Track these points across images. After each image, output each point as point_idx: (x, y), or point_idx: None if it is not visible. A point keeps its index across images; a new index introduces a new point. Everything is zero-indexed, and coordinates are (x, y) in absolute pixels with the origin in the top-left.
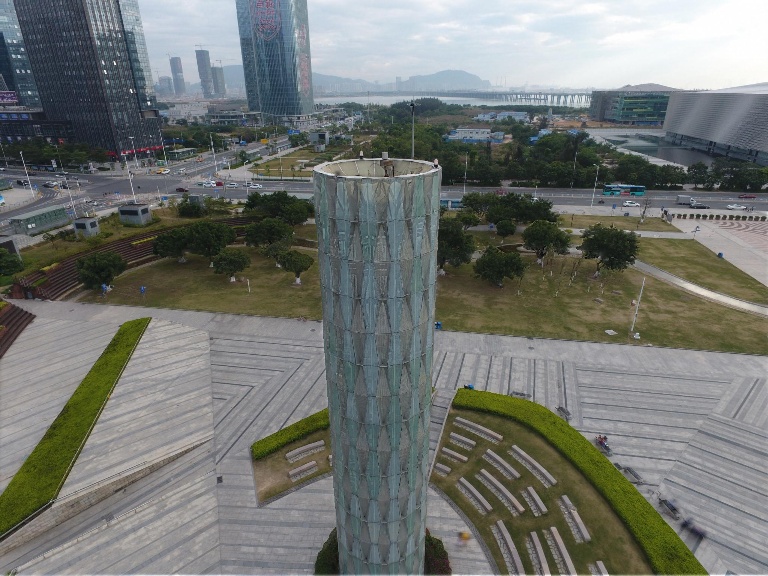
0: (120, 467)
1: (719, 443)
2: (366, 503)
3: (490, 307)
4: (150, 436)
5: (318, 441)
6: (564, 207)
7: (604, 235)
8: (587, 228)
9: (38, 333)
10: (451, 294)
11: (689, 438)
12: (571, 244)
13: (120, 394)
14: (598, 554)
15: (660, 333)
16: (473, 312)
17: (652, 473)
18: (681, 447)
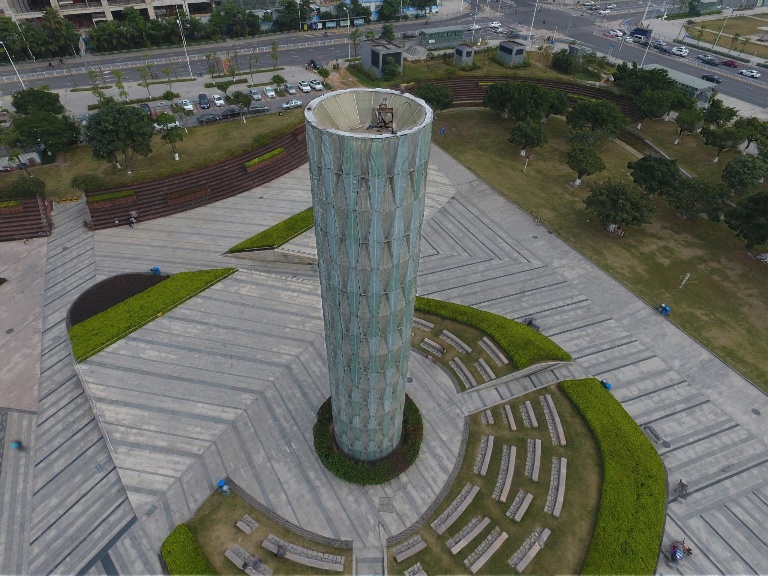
0: None
1: None
2: None
3: None
4: None
5: (430, 323)
6: None
7: None
8: None
9: None
10: (739, 289)
11: None
12: None
13: None
14: None
15: None
16: (738, 325)
17: None
18: None
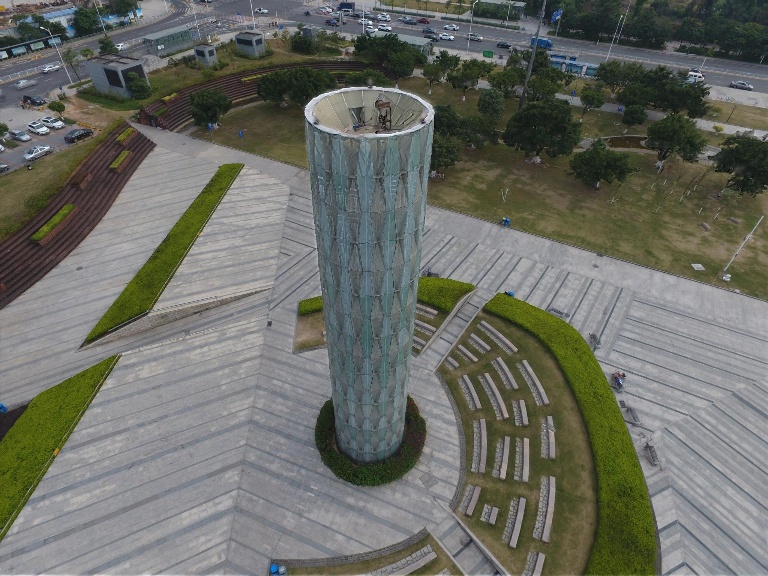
0: (198, 296)
1: (748, 411)
2: (346, 386)
3: (572, 211)
4: (224, 275)
5: None
6: (733, 91)
7: (750, 147)
8: (733, 134)
9: (156, 162)
10: (536, 188)
11: (717, 398)
12: (705, 150)
13: (208, 234)
14: (555, 471)
15: (759, 280)
16: (551, 213)
17: (654, 419)
18: (702, 404)
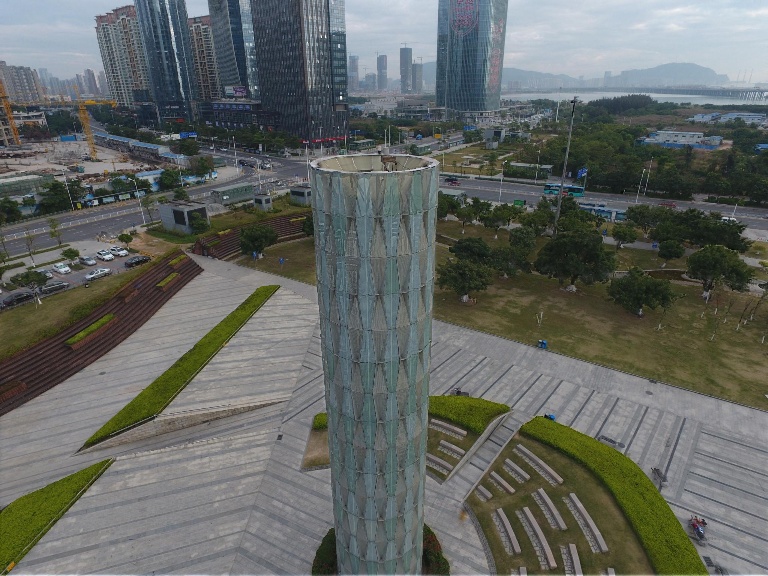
0: (211, 403)
1: None
2: (346, 493)
3: (616, 336)
4: (242, 385)
5: None
6: None
7: None
8: None
9: (200, 284)
10: (573, 314)
11: None
12: (754, 280)
13: (233, 345)
14: None
15: None
16: (592, 338)
17: None
18: None
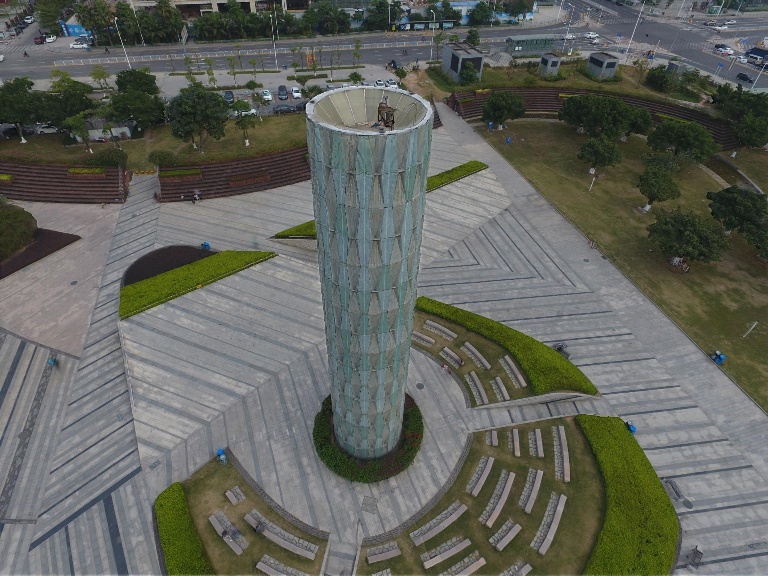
0: None
1: None
2: None
3: None
4: None
5: (454, 332)
6: None
7: None
8: None
9: None
10: None
11: None
12: None
13: None
14: None
15: None
16: None
17: None
18: None
